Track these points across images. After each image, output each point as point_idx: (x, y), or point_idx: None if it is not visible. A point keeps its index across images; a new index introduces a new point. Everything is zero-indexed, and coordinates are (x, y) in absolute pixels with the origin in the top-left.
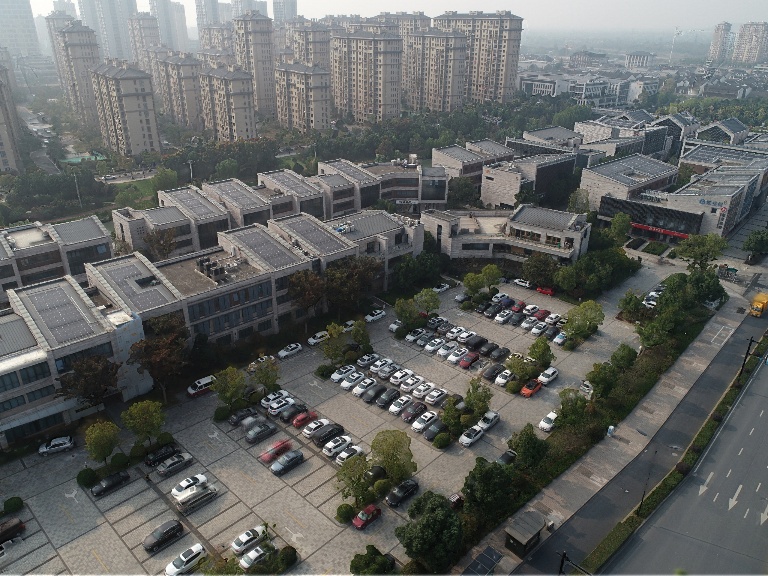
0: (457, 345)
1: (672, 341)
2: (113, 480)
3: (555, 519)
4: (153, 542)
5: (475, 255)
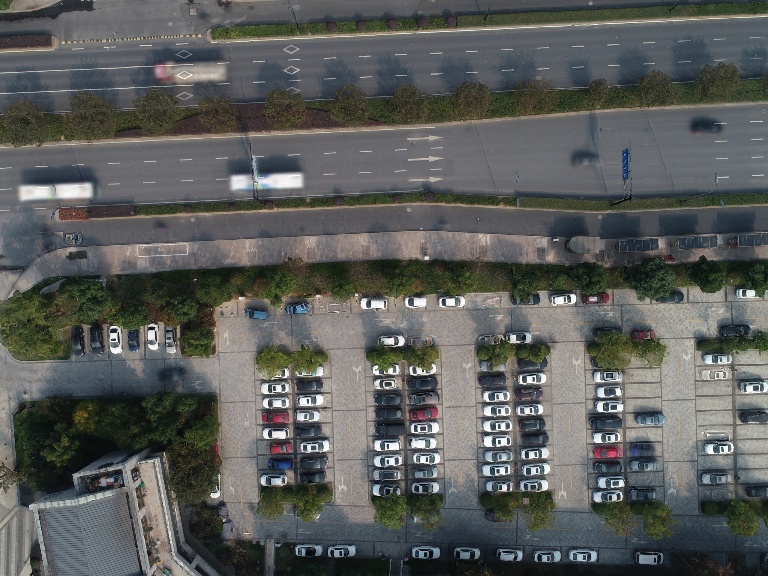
0: (414, 439)
1: (238, 279)
2: (762, 490)
3: (544, 242)
4: (765, 415)
5: (214, 573)
